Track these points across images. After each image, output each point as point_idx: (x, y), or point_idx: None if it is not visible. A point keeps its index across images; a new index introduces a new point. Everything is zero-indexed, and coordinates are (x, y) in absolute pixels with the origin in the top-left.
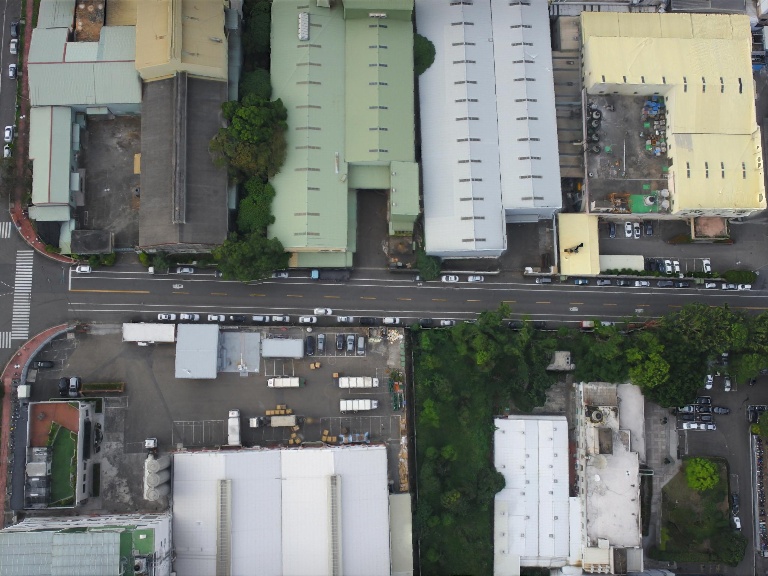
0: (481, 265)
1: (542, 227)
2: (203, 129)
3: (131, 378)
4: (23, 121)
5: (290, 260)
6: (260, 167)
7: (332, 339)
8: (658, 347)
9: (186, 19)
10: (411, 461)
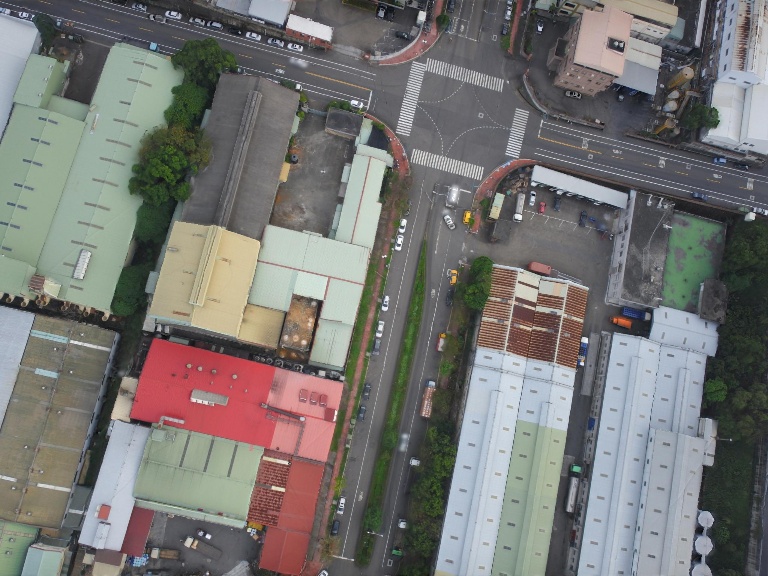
0: None
1: None
2: (213, 178)
3: (335, 5)
4: (385, 252)
5: None
6: None
7: None
8: None
9: (195, 272)
10: None
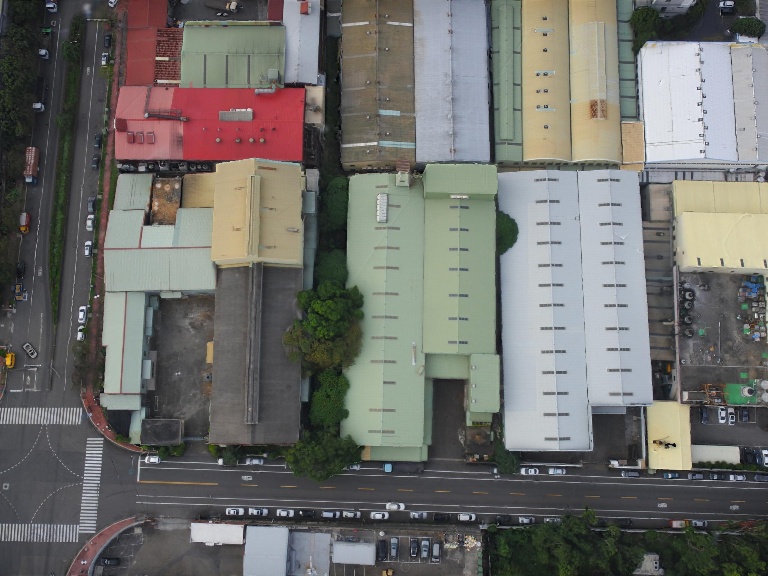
0: (562, 455)
1: (629, 415)
2: (277, 320)
3: None
4: (97, 301)
5: (363, 453)
6: (335, 361)
7: (405, 543)
8: (759, 564)
9: (264, 210)
10: None
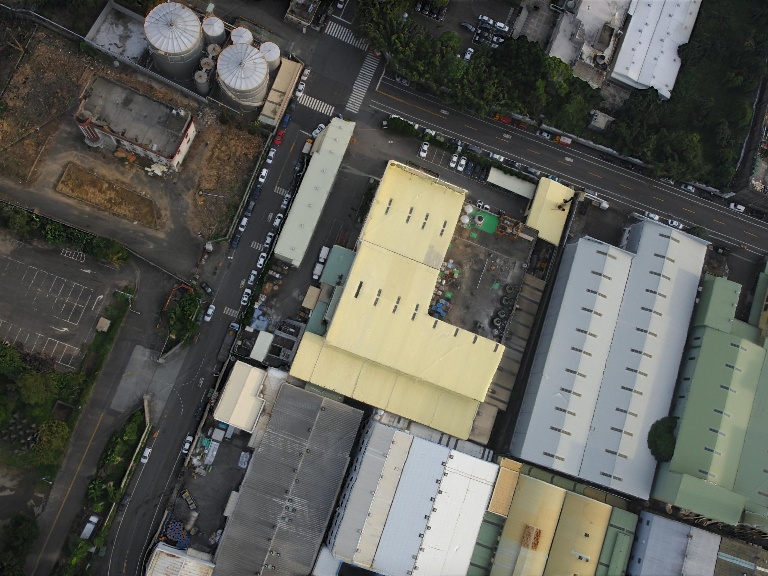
0: None
1: (576, 240)
2: None
3: None
4: None
5: None
6: None
7: None
8: None
9: None
10: (762, 89)
